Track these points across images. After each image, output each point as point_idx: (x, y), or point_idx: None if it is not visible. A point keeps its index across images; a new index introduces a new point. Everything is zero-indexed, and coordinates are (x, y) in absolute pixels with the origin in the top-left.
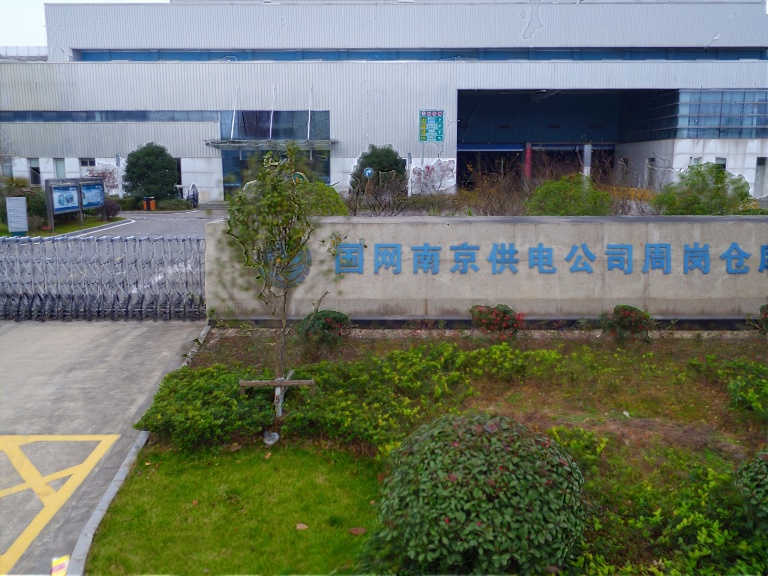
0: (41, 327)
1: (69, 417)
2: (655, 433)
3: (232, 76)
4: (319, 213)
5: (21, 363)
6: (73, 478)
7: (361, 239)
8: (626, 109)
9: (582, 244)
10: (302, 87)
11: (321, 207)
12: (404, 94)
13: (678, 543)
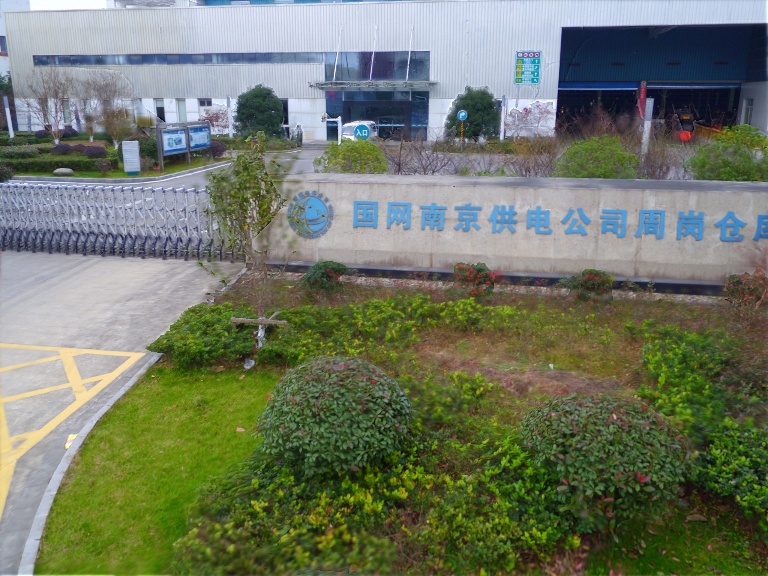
0: (120, 262)
1: (115, 337)
2: (559, 384)
3: (337, 17)
4: (357, 169)
5: (95, 292)
6: (102, 382)
7: (317, 210)
8: (756, 44)
9: (578, 208)
10: (404, 27)
11: (359, 164)
12: (506, 33)
13: (485, 464)
